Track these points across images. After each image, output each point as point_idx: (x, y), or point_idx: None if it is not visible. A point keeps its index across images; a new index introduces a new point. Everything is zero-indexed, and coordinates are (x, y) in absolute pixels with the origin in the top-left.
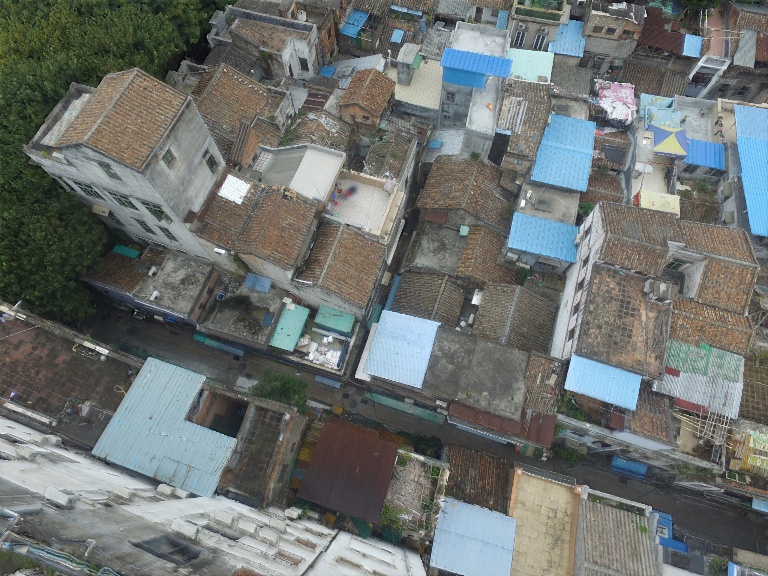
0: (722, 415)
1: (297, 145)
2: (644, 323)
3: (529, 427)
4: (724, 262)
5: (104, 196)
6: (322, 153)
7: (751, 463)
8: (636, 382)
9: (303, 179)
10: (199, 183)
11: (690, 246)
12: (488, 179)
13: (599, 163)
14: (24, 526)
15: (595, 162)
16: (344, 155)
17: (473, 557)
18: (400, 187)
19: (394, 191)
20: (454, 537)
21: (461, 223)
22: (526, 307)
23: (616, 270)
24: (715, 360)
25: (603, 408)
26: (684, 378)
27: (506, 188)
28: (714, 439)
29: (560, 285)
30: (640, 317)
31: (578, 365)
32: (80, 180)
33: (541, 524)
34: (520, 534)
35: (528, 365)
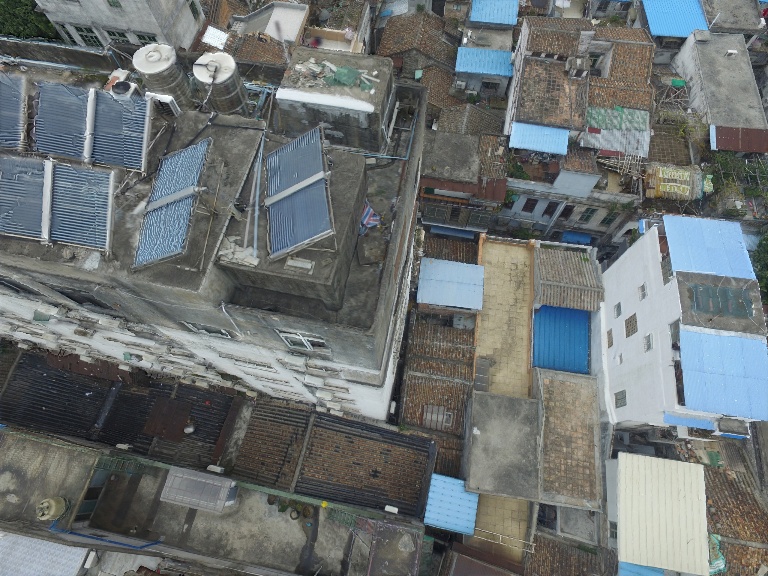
0: (636, 155)
1: (265, 6)
2: (568, 94)
3: (486, 190)
4: (627, 45)
5: (103, 41)
6: (288, 9)
7: (662, 190)
8: (565, 135)
9: (274, 29)
10: (185, 24)
11: (600, 37)
12: (434, 27)
13: (527, 10)
14: (119, 47)
15: (524, 10)
16: (307, 7)
17: (451, 293)
18: (359, 42)
19: (354, 38)
20: (434, 282)
21: (415, 68)
22: (476, 120)
23: (542, 60)
24: (627, 117)
25: (541, 158)
26: (604, 134)
27: (450, 34)
28: (631, 173)
29: (504, 104)
30: (564, 90)
31: (518, 129)
32: (82, 23)
33: (506, 275)
34: (489, 284)
35: (480, 143)
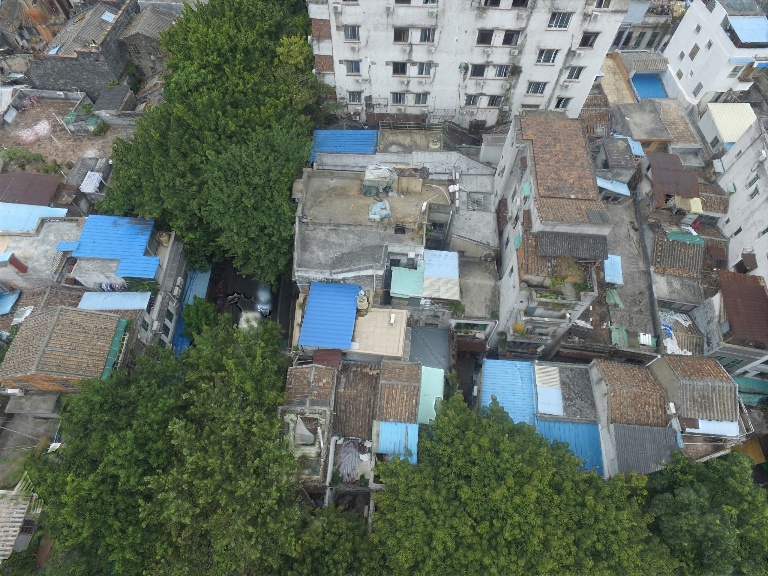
0: None
1: None
2: None
3: None
4: None
5: None
6: None
7: None
8: None
9: None
10: None
11: None
12: None
13: None
14: None
15: None
16: None
17: None
18: None
19: None
20: None
21: None
22: None
23: None
24: None
25: None
26: None
27: None
28: (664, 3)
29: None
30: None
31: None
32: None
33: (605, 70)
34: None
35: None
